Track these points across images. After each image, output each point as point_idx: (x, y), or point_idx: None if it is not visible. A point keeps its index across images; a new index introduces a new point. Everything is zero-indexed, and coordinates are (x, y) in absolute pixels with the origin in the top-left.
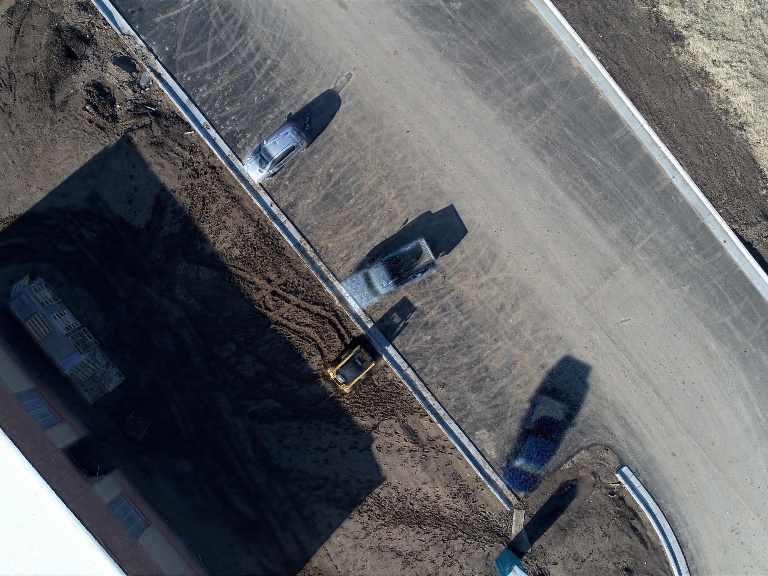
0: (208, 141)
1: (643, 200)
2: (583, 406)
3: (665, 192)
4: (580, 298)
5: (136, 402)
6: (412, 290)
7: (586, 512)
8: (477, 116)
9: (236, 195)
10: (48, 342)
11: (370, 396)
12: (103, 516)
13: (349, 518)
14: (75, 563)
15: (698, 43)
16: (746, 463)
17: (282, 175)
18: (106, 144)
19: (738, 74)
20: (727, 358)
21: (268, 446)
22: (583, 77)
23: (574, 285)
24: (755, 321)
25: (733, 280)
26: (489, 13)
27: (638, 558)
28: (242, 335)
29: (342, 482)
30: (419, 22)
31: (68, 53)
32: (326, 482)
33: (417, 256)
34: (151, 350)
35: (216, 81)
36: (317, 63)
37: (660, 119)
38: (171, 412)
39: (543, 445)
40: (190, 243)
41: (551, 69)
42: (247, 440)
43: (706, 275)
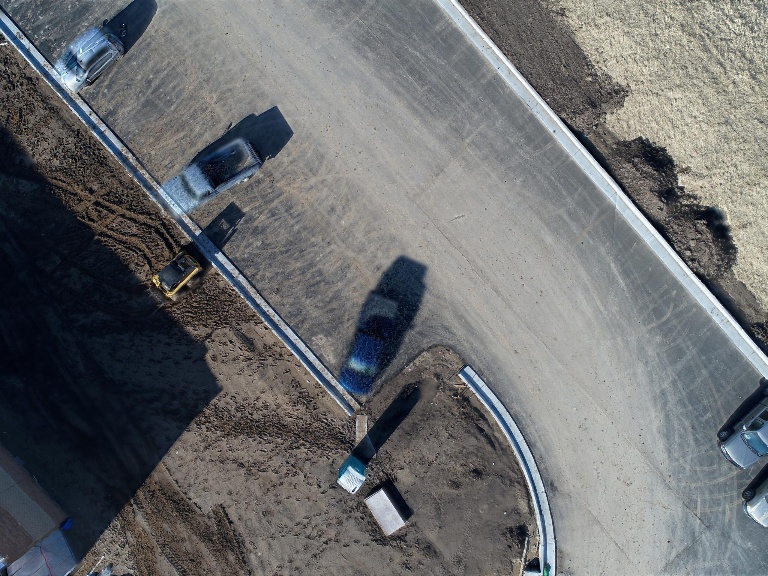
0: (21, 51)
1: (469, 93)
2: (421, 306)
3: (491, 84)
4: (412, 196)
5: None
6: (240, 195)
7: (430, 415)
8: (296, 15)
9: (54, 106)
10: None
11: (202, 305)
12: None
13: (186, 431)
14: None
15: None
16: (590, 357)
17: (100, 83)
18: None
19: None
20: (564, 250)
21: (99, 360)
22: None
23: (405, 183)
24: (590, 211)
25: (565, 170)
26: None
27: (486, 459)
28: (66, 248)
29: (177, 394)
30: None
31: None
32: (161, 395)
33: (243, 160)
34: None
35: None
36: None
37: (481, 9)
38: None
39: (382, 348)
40: (8, 156)
41: None
42: (77, 355)
43: (538, 167)
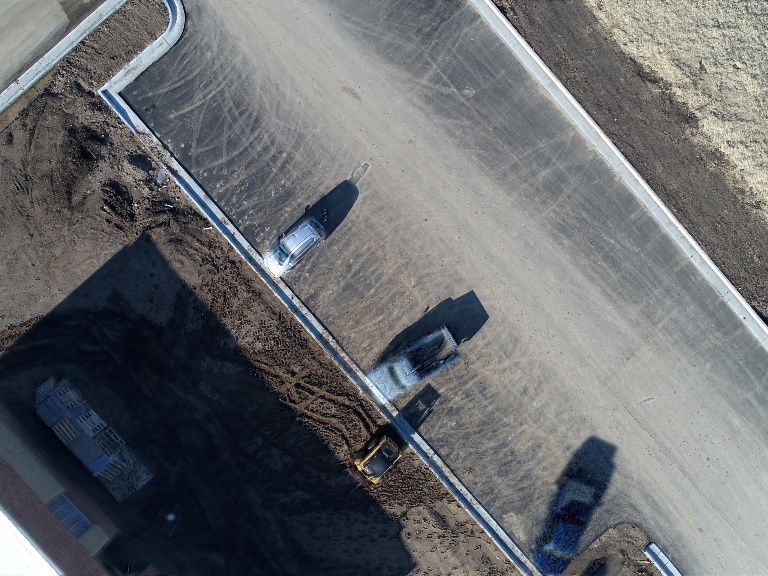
0: (227, 237)
1: (662, 280)
2: (609, 485)
3: (684, 271)
4: (603, 379)
5: (164, 500)
6: (435, 377)
7: None
8: (494, 202)
9: (257, 289)
10: (75, 446)
11: (397, 484)
12: None
13: None
14: None
15: (712, 125)
16: None
17: (302, 267)
18: (125, 243)
19: (753, 154)
20: (750, 433)
21: (297, 538)
22: (599, 160)
23: (596, 366)
24: None
25: (754, 356)
26: (503, 100)
27: None
28: (268, 429)
29: (372, 571)
30: (434, 111)
31: (84, 154)
32: (356, 571)
33: (439, 343)
34: (177, 447)
35: (233, 176)
36: (333, 155)
37: (677, 200)
38: (199, 508)
39: (571, 525)
40: (213, 339)
41: (567, 153)
42: (276, 533)
43: (727, 352)
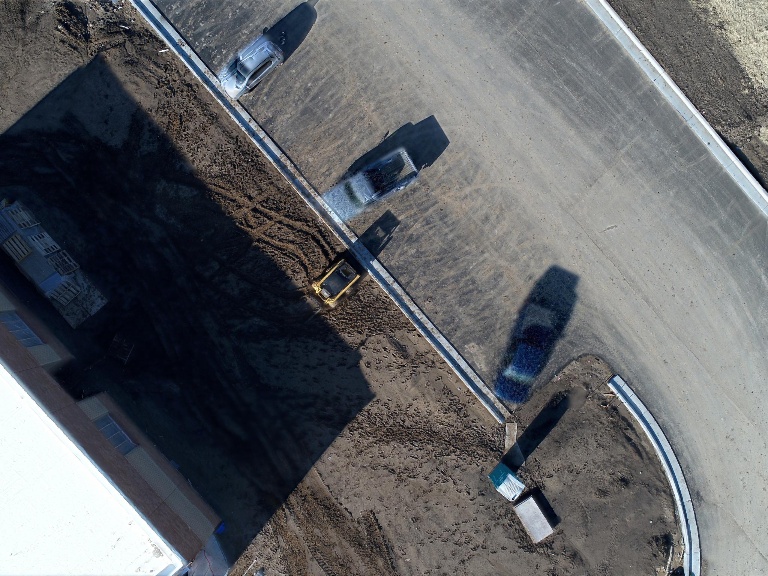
0: (183, 58)
1: (625, 104)
2: (572, 316)
3: (647, 95)
4: (565, 206)
5: (119, 325)
6: (395, 203)
7: (579, 423)
8: (455, 25)
9: (214, 113)
10: (27, 264)
11: (356, 312)
12: (87, 431)
13: (339, 437)
14: (59, 477)
15: None
16: (738, 368)
17: (260, 91)
18: (80, 64)
19: None
20: (715, 262)
21: (255, 366)
22: None
23: (559, 193)
24: (742, 223)
25: (719, 182)
26: None
27: (633, 468)
28: (224, 253)
29: (331, 400)
30: None
31: None
32: (315, 401)
33: (399, 169)
34: (132, 272)
35: None
36: None
37: (639, 21)
38: (155, 334)
39: (533, 357)
40: (168, 162)
41: None
42: (233, 360)
43: (691, 178)
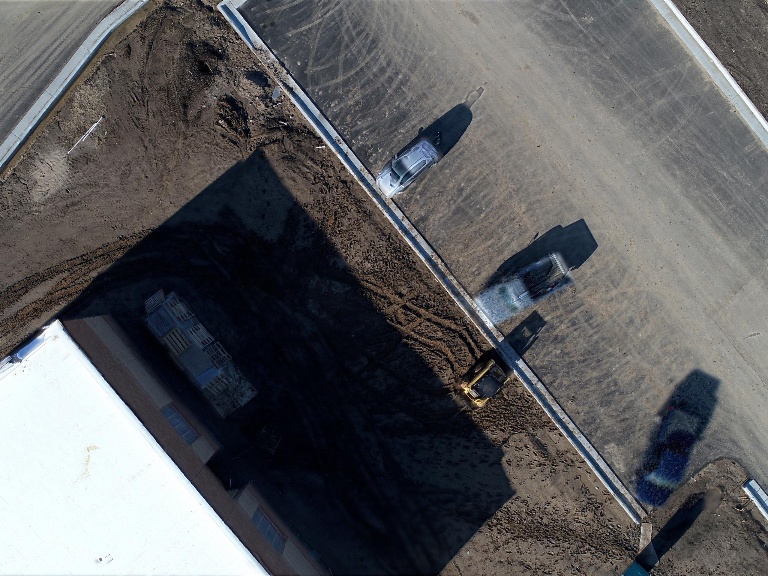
0: (340, 156)
1: None
2: (711, 420)
3: None
4: (709, 312)
5: (268, 416)
6: (542, 304)
7: (713, 525)
8: (608, 131)
9: (367, 209)
10: (185, 357)
11: (500, 410)
12: (253, 532)
13: (479, 532)
14: None
15: None
16: None
17: (413, 189)
18: (239, 159)
19: None
20: None
21: (399, 460)
22: (714, 92)
23: (703, 299)
24: None
25: None
26: (621, 28)
27: (765, 571)
28: (374, 349)
29: (472, 496)
30: (551, 37)
31: (201, 68)
32: (456, 496)
33: (547, 270)
34: (283, 364)
35: (348, 96)
36: (448, 78)
37: None
38: (303, 426)
39: (671, 459)
40: (322, 257)
41: (682, 84)
42: (378, 454)
43: None
